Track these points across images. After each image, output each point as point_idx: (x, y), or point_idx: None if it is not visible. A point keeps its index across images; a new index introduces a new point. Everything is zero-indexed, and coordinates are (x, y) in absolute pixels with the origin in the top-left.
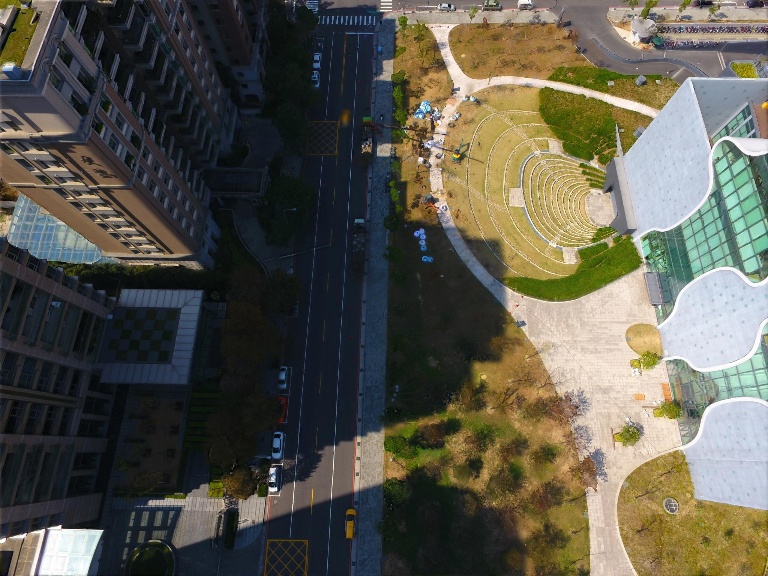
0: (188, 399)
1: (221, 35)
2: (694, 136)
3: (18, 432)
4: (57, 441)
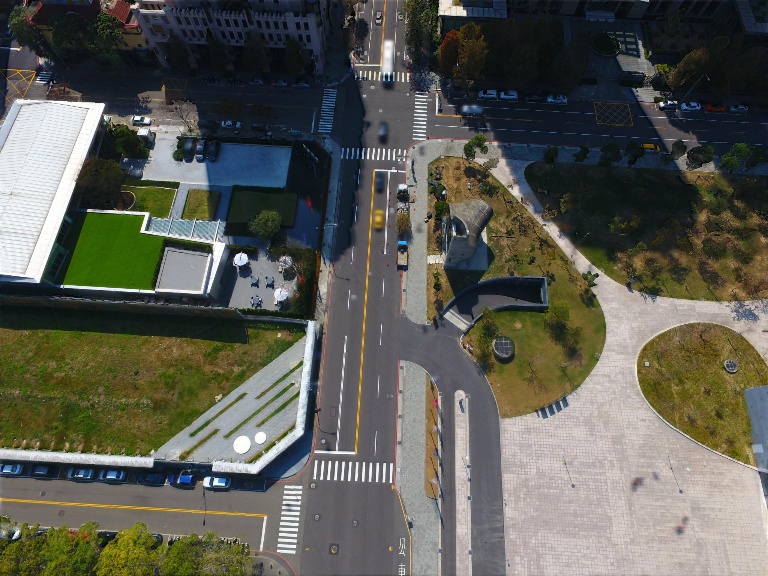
0: None
1: None
2: None
3: None
4: None
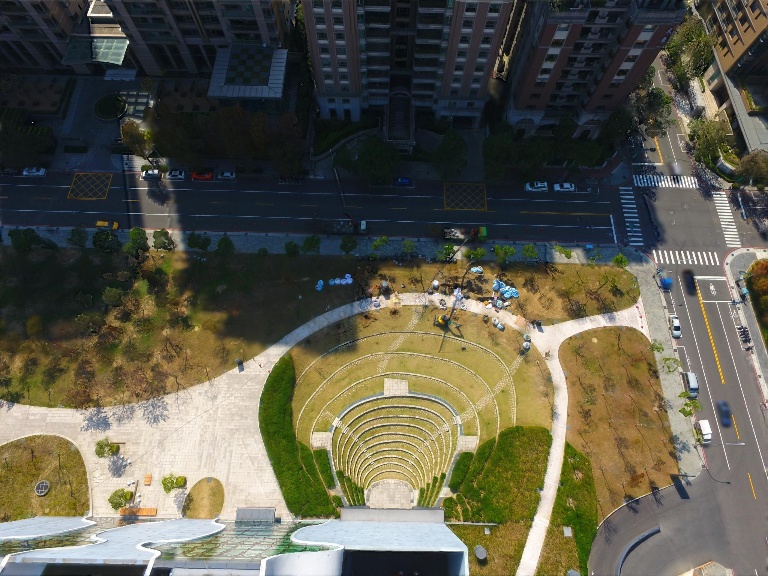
0: None
1: None
2: (380, 542)
3: None
4: (174, 27)
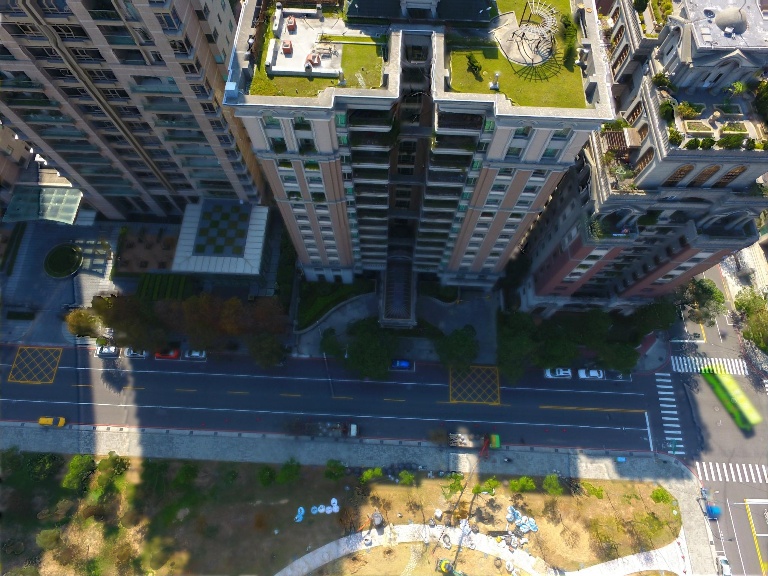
0: (186, 273)
1: (548, 260)
2: None
3: (122, 156)
4: (135, 182)
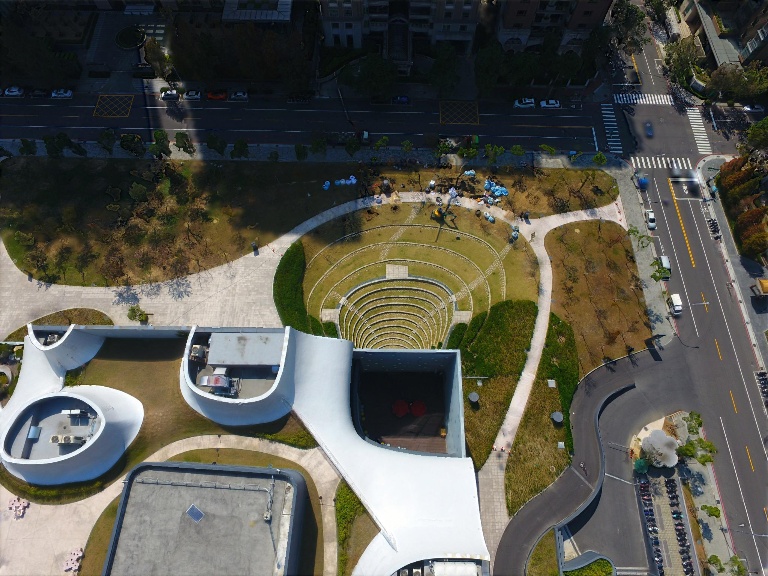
0: None
1: None
2: None
3: None
4: None
